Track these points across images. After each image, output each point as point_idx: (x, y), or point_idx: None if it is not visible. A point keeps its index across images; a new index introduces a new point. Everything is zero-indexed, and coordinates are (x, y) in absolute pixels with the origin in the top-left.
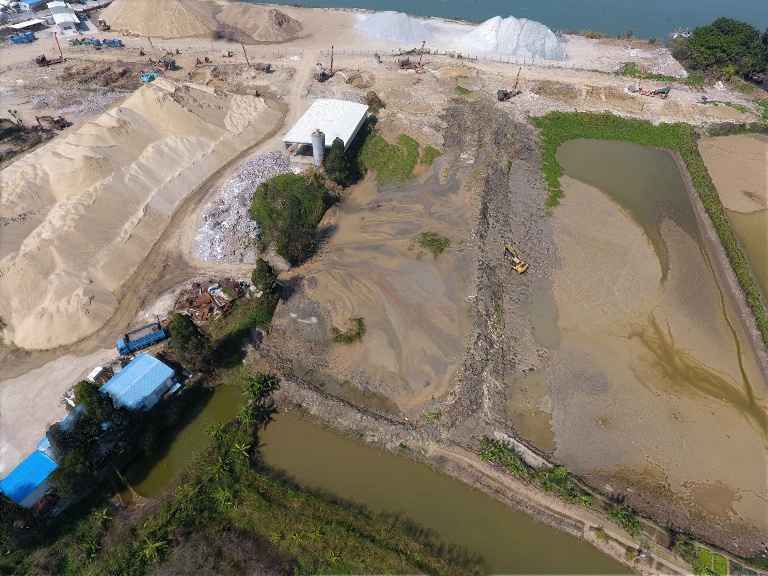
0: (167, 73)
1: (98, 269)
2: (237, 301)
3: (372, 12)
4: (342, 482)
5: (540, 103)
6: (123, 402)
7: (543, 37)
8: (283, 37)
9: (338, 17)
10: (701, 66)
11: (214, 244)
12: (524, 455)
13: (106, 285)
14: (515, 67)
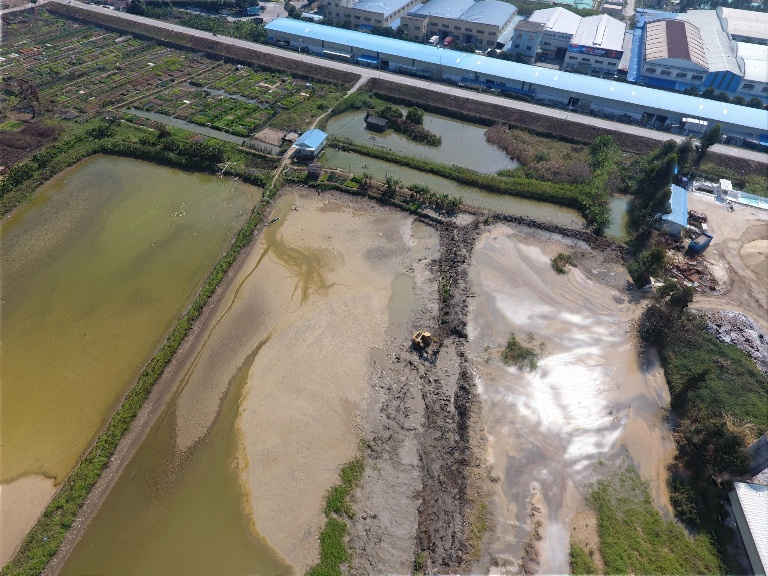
0: None
1: None
2: None
3: None
4: (528, 211)
5: None
6: None
7: None
8: None
9: None
10: None
11: None
12: (433, 213)
13: None
14: None
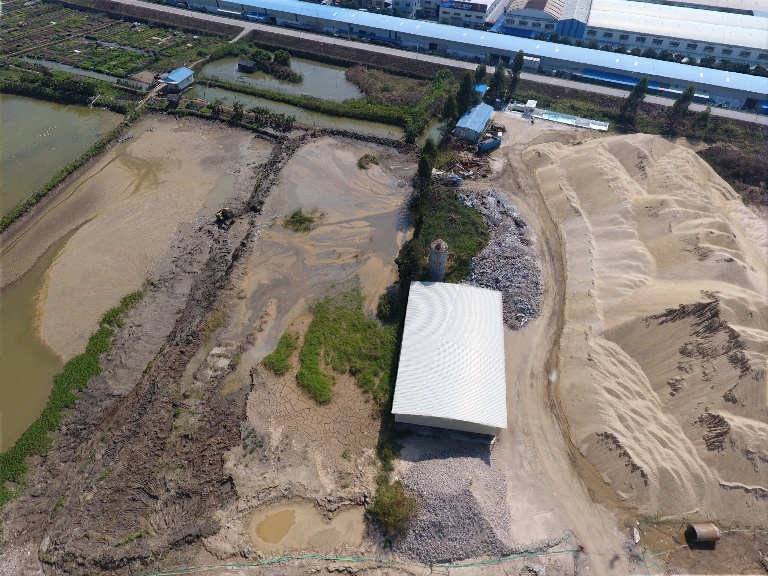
0: None
1: None
2: None
3: None
4: None
5: None
6: None
7: None
8: None
9: None
10: None
11: None
12: None
13: None
14: None
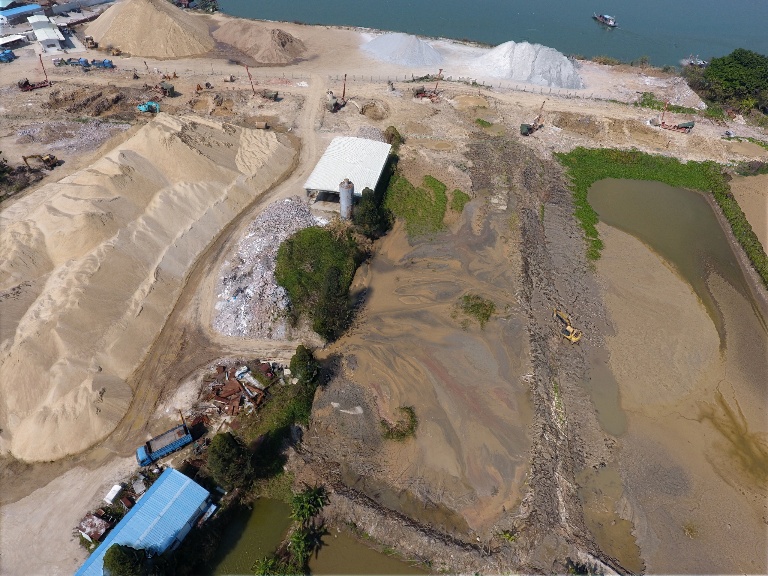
0: (165, 100)
1: (108, 353)
2: (270, 389)
3: (377, 31)
4: None
5: (564, 138)
6: (152, 540)
7: (559, 64)
8: (287, 59)
9: (342, 36)
10: (720, 98)
11: (239, 317)
12: None
13: (117, 372)
14: (532, 96)
